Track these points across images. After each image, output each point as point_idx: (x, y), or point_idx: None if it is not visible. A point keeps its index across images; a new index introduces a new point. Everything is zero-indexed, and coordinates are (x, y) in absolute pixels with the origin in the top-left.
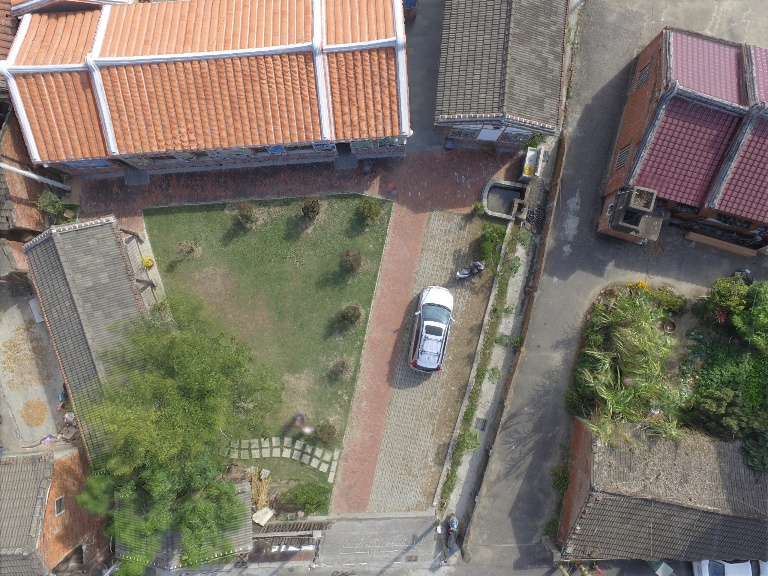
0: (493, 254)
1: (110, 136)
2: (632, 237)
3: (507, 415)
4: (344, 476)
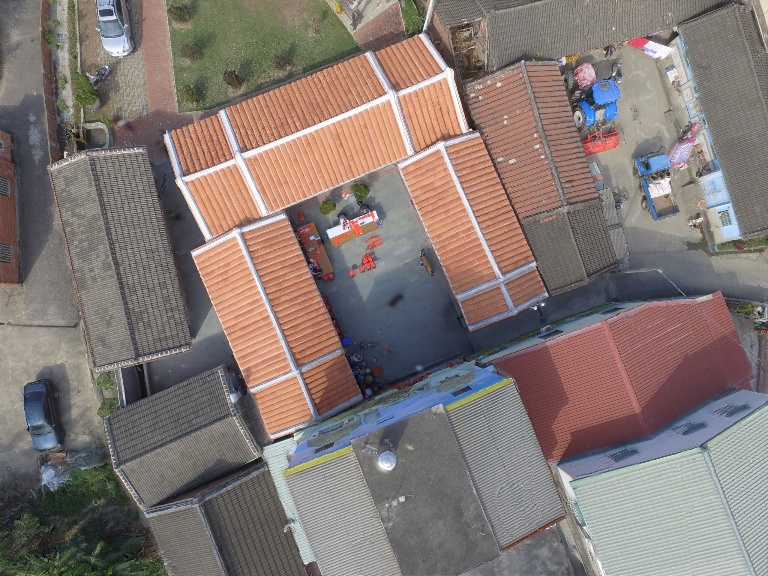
0: None
1: (372, 60)
2: None
3: None
4: None
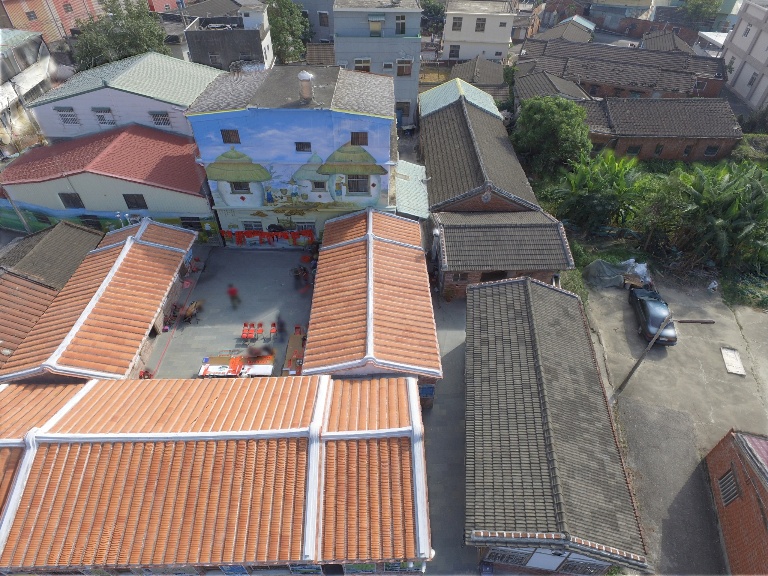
0: None
1: (0, 538)
2: None
3: None
4: None
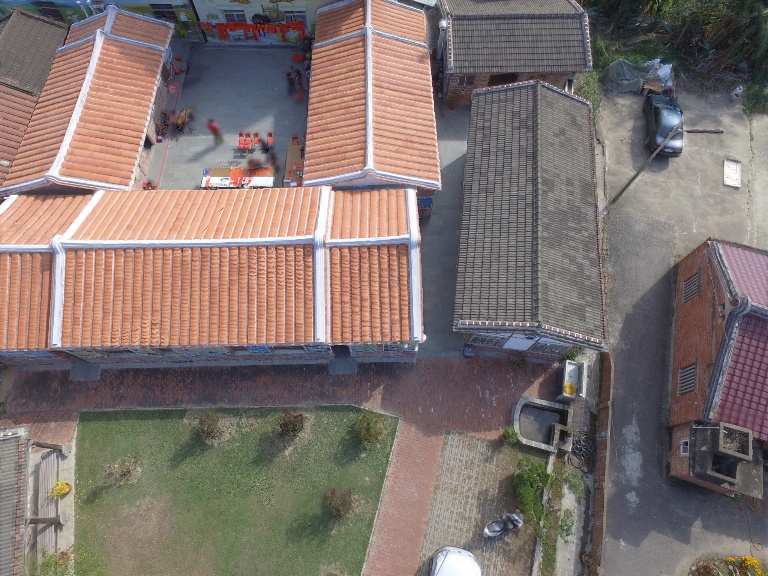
0: (534, 503)
1: (56, 325)
2: (722, 488)
3: None
4: None
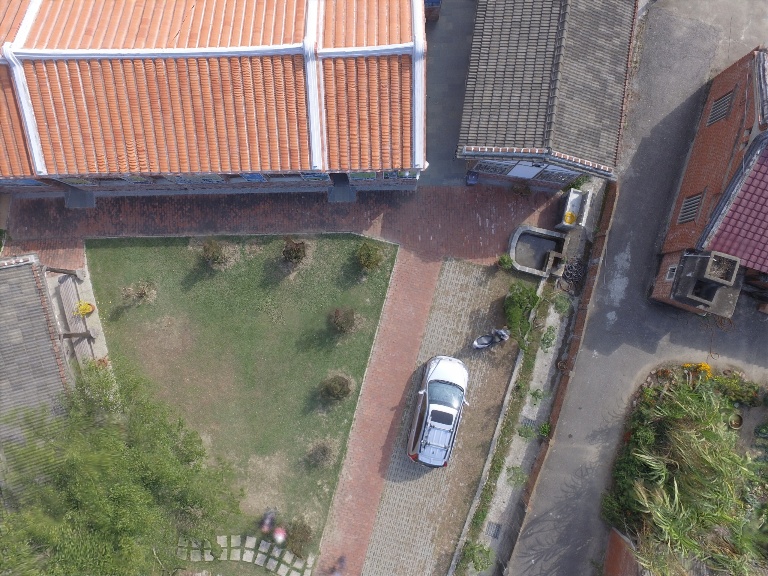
0: (521, 321)
1: (35, 151)
2: (697, 309)
3: (527, 520)
4: None
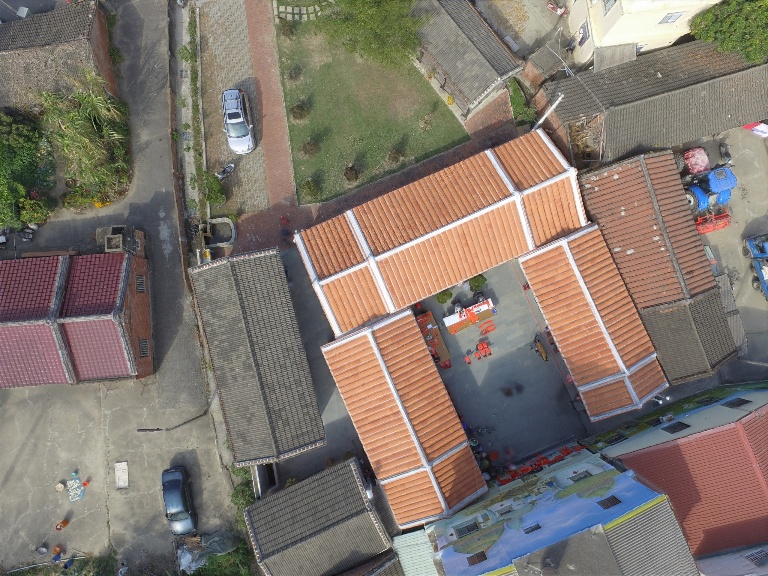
0: None
1: (493, 159)
2: None
3: None
4: (267, 8)
